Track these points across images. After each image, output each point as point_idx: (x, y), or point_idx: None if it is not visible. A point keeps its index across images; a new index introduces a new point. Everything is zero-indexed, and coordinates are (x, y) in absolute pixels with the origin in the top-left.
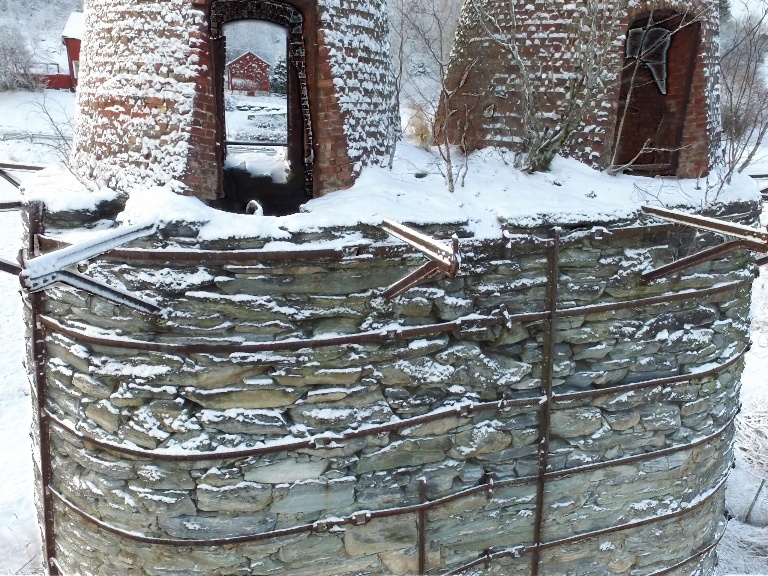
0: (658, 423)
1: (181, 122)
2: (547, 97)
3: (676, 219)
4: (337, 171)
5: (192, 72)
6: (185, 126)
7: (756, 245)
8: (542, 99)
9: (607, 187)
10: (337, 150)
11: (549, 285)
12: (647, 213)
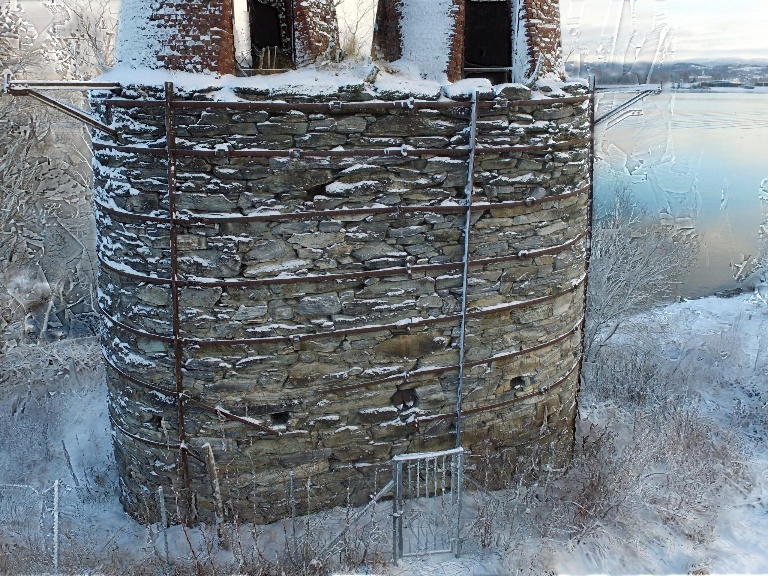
0: None
1: None
2: None
3: None
4: None
5: None
6: None
7: None
8: None
9: None
10: None
11: None
12: None
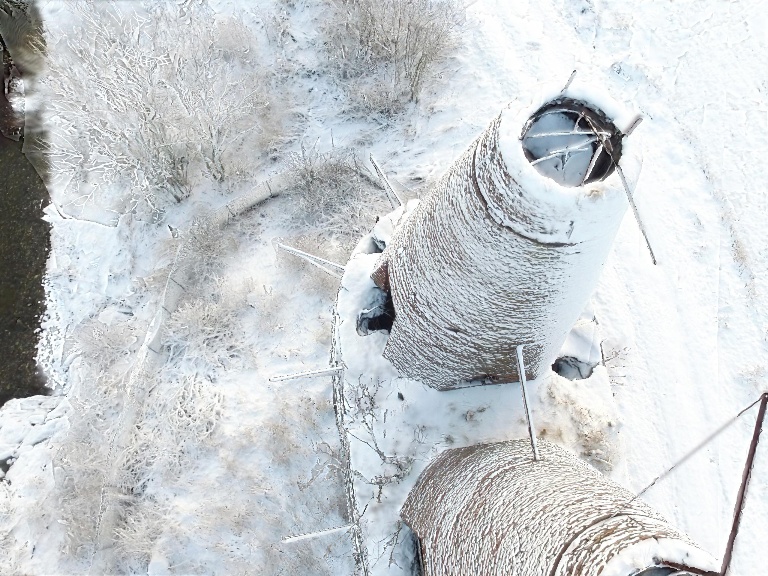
0: None
1: None
2: None
3: None
4: None
5: None
6: None
7: None
8: None
9: (378, 507)
10: None
11: None
12: None
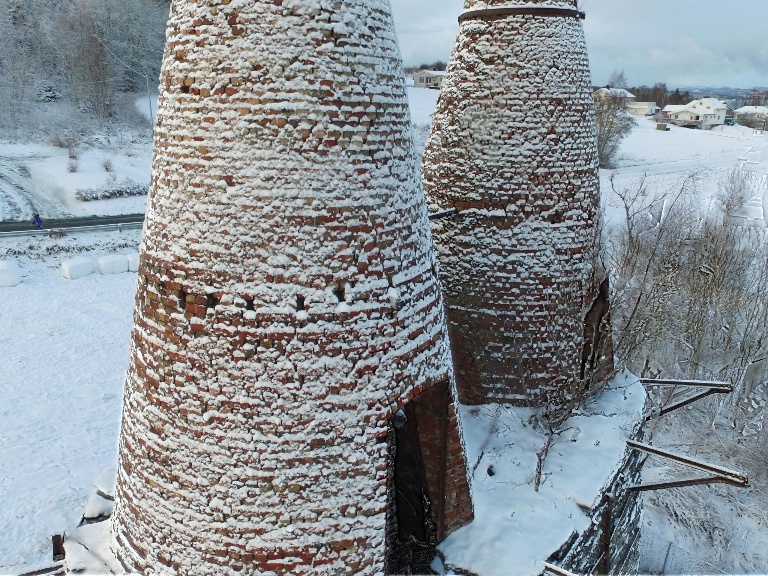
0: (629, 574)
1: (375, 555)
2: (539, 362)
3: (661, 455)
4: (460, 512)
5: (382, 504)
6: (379, 557)
7: (736, 483)
8: (535, 364)
9: (600, 431)
10: (460, 496)
11: (603, 534)
12: (632, 447)
